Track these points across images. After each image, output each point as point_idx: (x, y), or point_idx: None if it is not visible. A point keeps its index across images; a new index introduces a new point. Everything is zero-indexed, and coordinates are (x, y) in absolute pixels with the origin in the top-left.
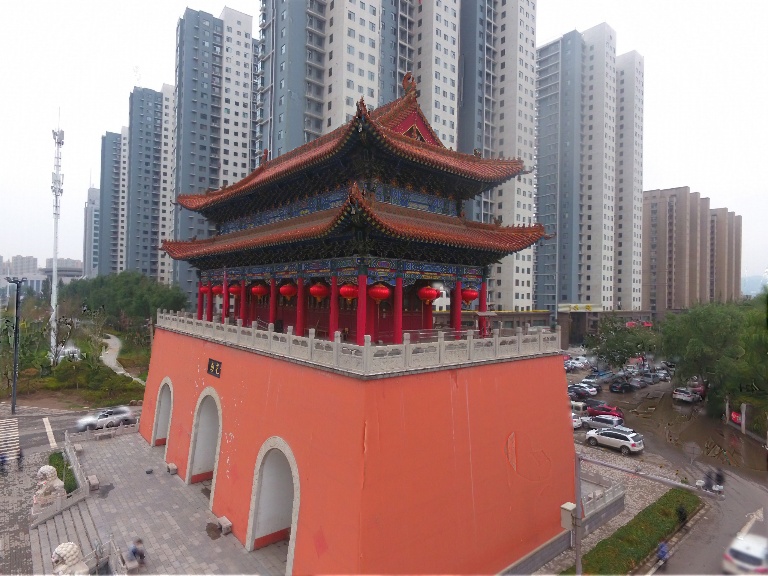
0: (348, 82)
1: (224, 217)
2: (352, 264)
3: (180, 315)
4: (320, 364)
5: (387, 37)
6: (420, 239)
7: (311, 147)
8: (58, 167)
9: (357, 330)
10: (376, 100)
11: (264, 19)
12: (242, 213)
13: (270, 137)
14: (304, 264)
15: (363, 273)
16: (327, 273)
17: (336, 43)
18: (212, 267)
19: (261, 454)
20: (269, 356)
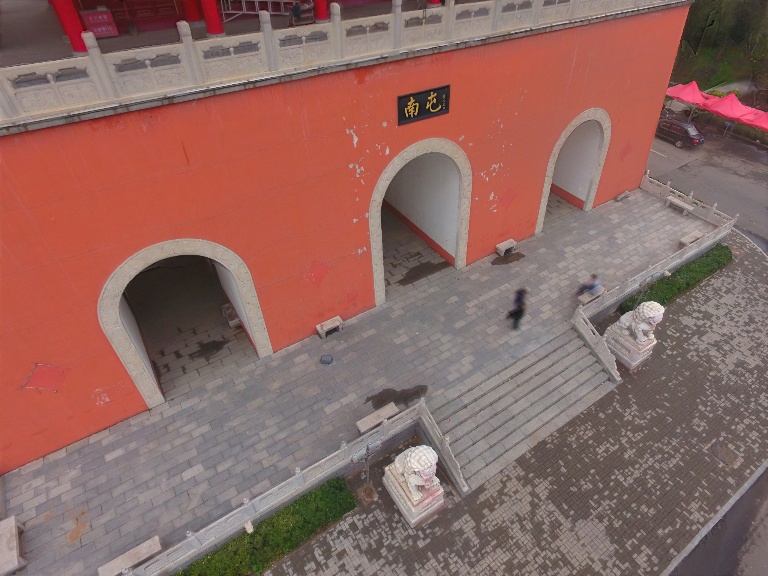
0: None
1: None
2: None
3: None
4: (655, 5)
5: None
6: None
7: None
8: None
9: None
10: None
11: None
12: None
13: None
14: None
15: None
16: None
17: None
18: None
19: (560, 144)
20: None
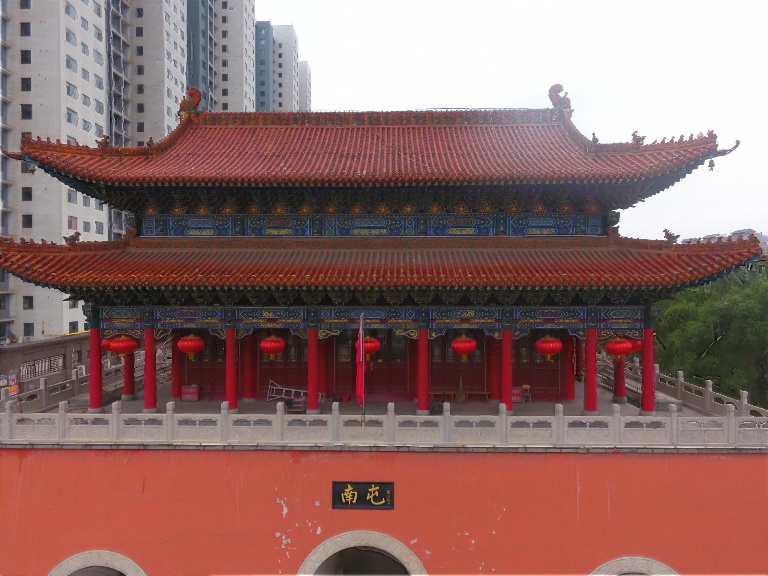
0: None
1: (166, 204)
2: (633, 315)
3: (0, 404)
4: (710, 447)
5: None
6: None
7: (349, 121)
8: None
9: (648, 393)
10: (103, 22)
11: None
12: (244, 206)
13: None
14: (520, 310)
15: None
16: (576, 324)
17: None
18: (158, 301)
19: None
20: (575, 452)
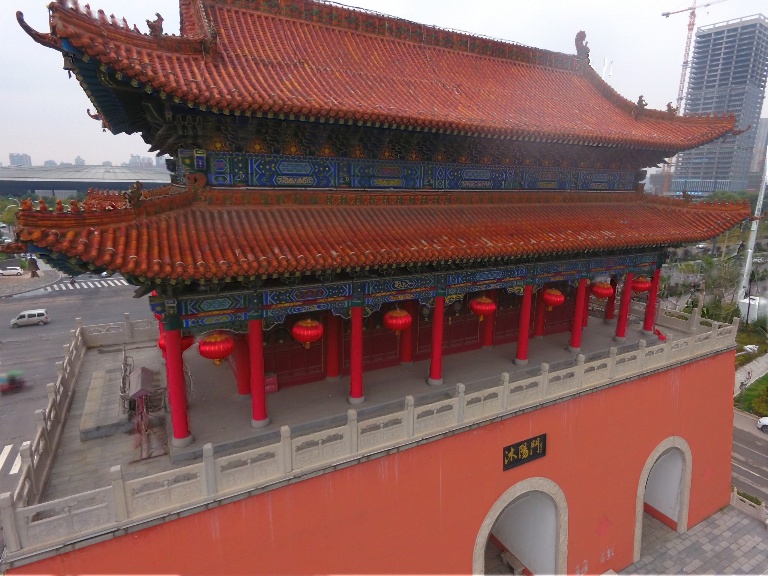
0: None
1: None
2: None
3: None
4: None
5: None
6: None
7: None
8: None
9: None
10: None
11: None
12: None
13: None
14: None
15: None
16: None
17: None
18: None
19: None
20: None
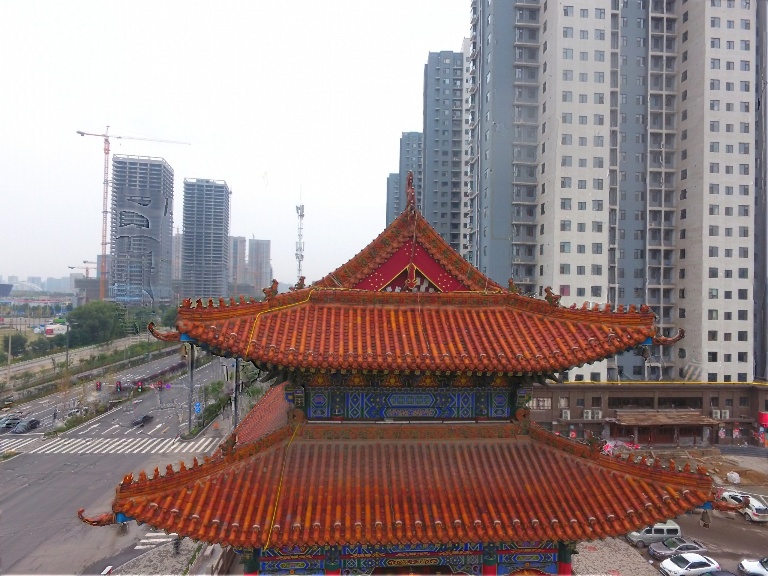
0: (565, 95)
1: None
2: None
3: None
4: None
5: (631, 16)
6: (309, 545)
7: None
8: (301, 236)
9: None
10: (608, 106)
11: (474, 48)
12: None
13: (478, 177)
14: None
15: (245, 569)
16: None
17: (549, 51)
18: None
19: None
20: None
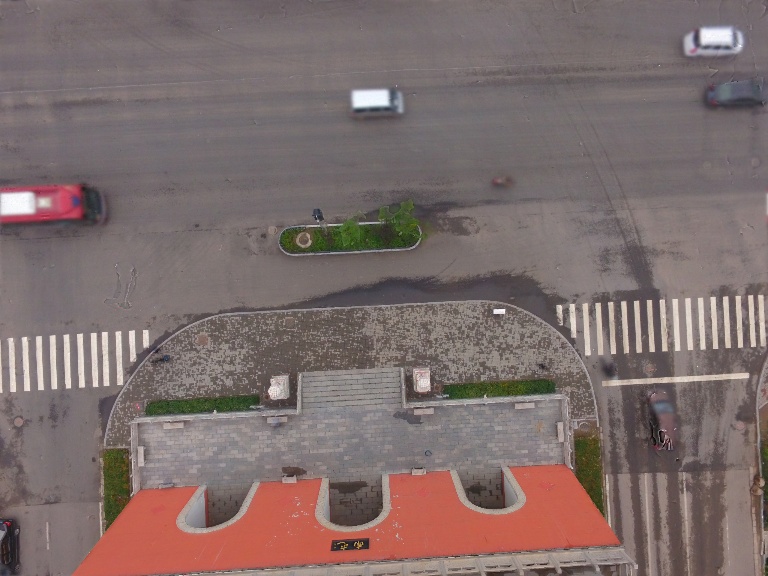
0: None
1: None
2: None
3: None
4: None
5: None
6: None
7: None
8: None
9: None
10: None
11: None
12: None
13: None
14: None
15: None
16: None
17: None
18: None
19: (234, 519)
20: (211, 571)
